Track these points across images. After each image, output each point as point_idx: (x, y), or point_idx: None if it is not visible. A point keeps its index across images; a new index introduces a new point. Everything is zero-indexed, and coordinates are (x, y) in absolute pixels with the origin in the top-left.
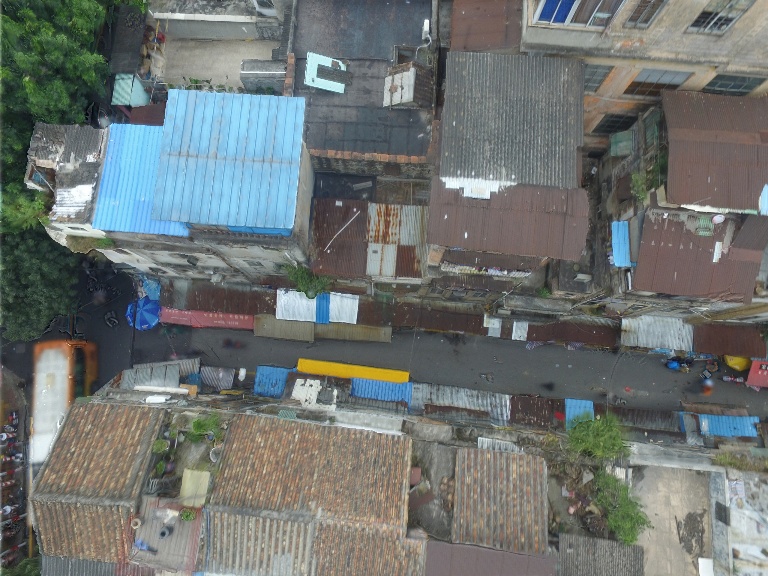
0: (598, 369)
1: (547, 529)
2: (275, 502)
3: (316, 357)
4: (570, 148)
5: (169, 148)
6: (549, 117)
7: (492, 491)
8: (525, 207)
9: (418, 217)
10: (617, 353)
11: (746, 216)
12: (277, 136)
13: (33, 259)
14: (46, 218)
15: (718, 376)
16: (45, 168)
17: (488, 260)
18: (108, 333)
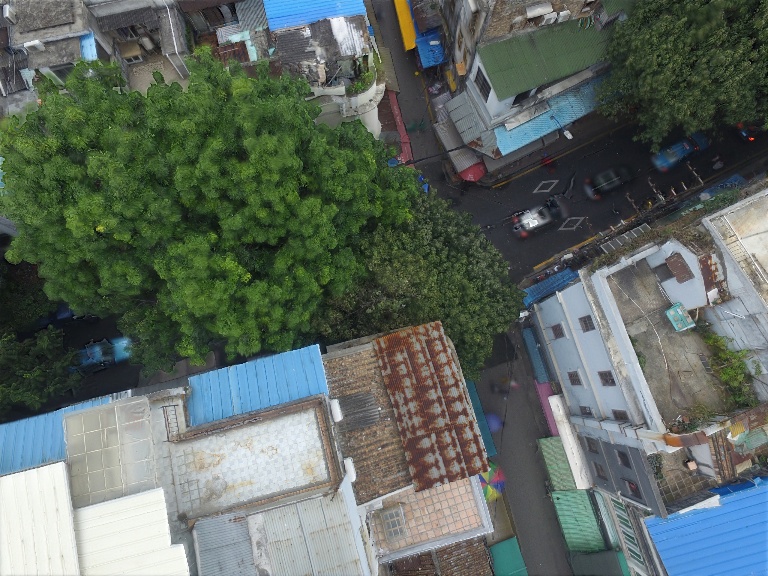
0: None
1: None
2: None
3: (400, 67)
4: None
5: None
6: None
7: None
8: None
9: None
10: None
11: None
12: None
13: None
14: (368, 73)
15: None
16: None
17: None
18: None
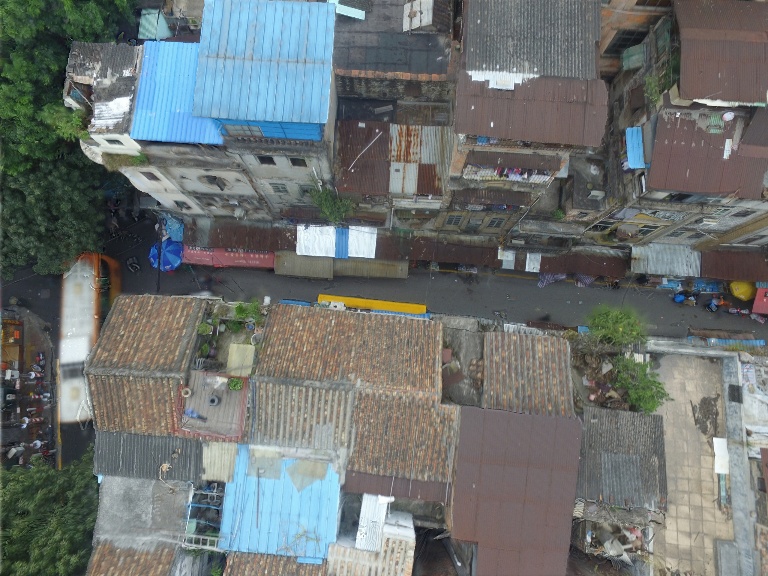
0: (608, 305)
1: (572, 398)
2: (316, 374)
3: None
4: (589, 43)
5: (207, 50)
6: (568, 15)
7: (519, 367)
8: (547, 98)
9: (438, 137)
10: (626, 289)
11: (755, 110)
12: (310, 39)
13: (66, 186)
14: (84, 133)
15: (724, 309)
16: (82, 85)
17: (510, 160)
18: (130, 278)
